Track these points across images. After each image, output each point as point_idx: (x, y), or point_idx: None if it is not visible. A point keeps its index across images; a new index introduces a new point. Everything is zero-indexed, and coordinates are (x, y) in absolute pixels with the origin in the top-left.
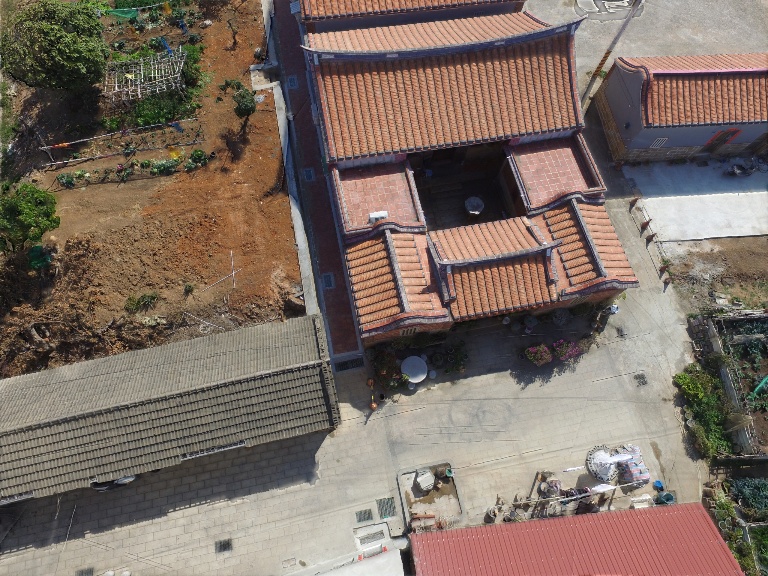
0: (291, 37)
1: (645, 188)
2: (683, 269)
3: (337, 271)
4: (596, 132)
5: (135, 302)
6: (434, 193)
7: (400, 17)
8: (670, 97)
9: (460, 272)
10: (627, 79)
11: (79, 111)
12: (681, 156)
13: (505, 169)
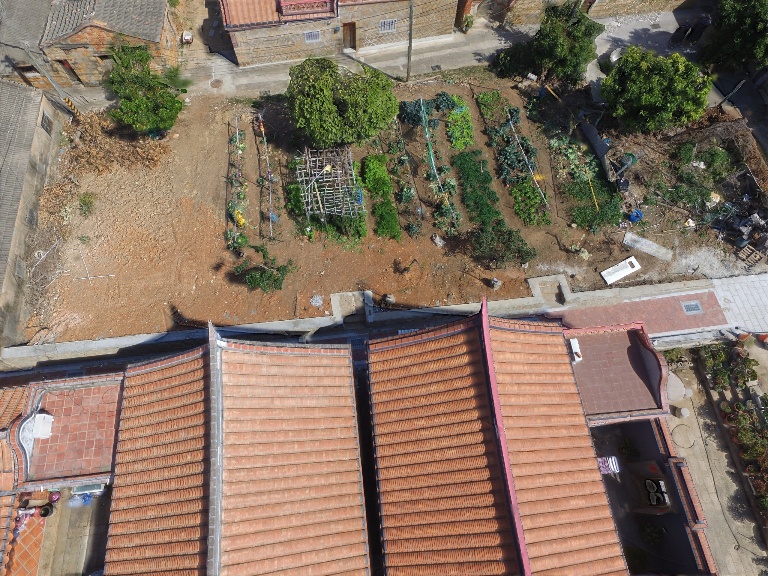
0: None
1: None
2: None
3: None
4: None
5: (86, 199)
6: None
7: None
8: None
9: None
10: None
11: None
12: None
13: None
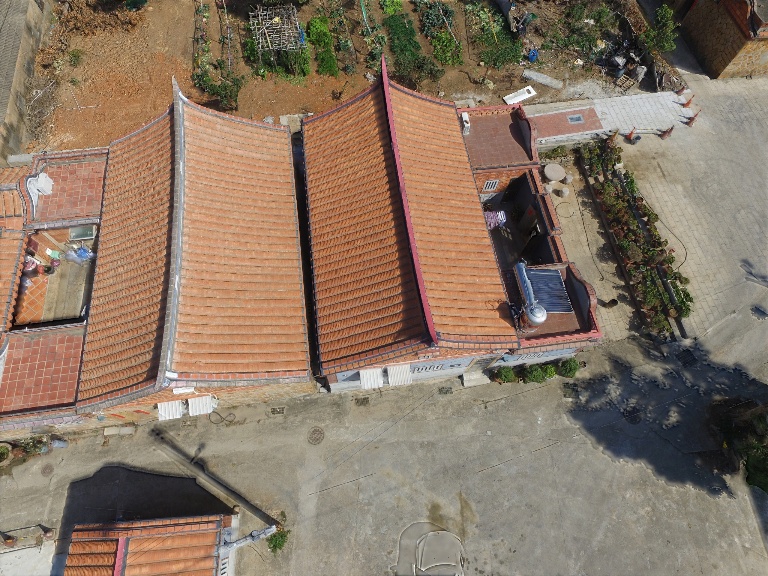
0: None
1: None
2: None
3: None
4: (176, 503)
5: (75, 53)
6: None
7: None
8: None
9: None
10: None
11: None
12: None
13: None
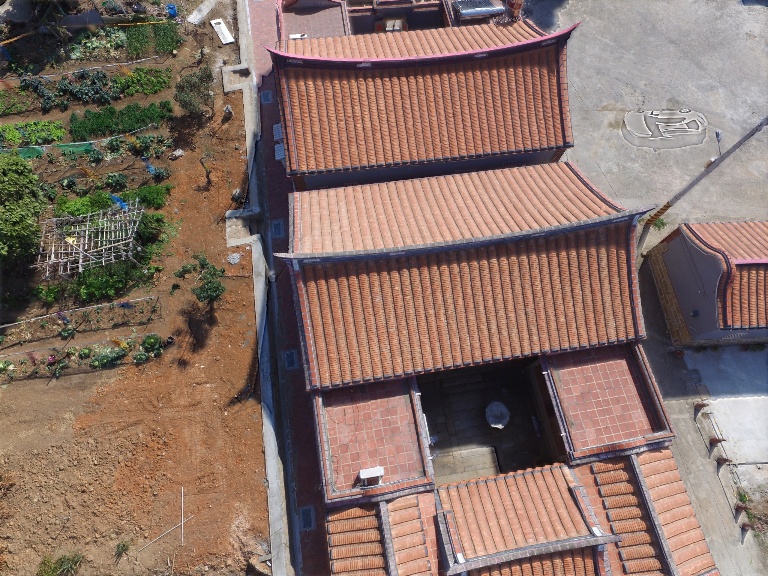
0: (279, 167)
1: (713, 384)
2: (766, 510)
3: (319, 503)
4: (650, 303)
5: (50, 569)
6: (446, 386)
7: (410, 167)
8: (755, 291)
9: (479, 573)
10: (697, 256)
11: (11, 274)
12: (759, 341)
13: (538, 370)
